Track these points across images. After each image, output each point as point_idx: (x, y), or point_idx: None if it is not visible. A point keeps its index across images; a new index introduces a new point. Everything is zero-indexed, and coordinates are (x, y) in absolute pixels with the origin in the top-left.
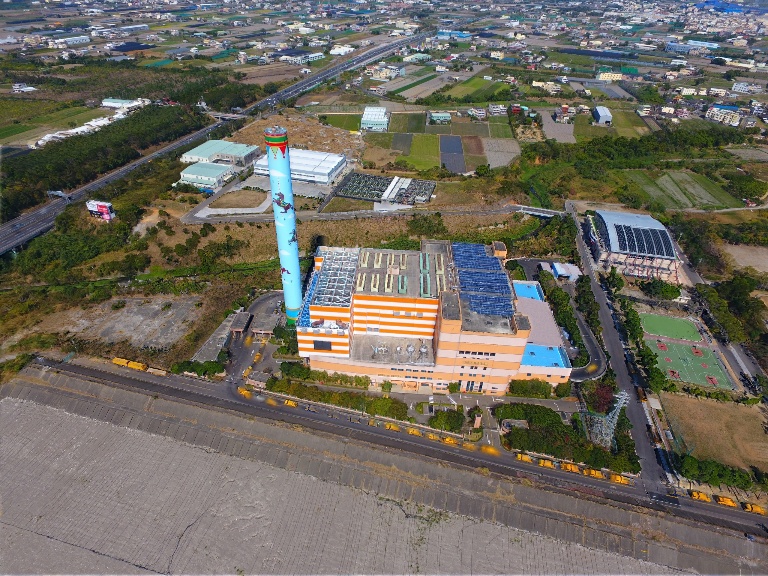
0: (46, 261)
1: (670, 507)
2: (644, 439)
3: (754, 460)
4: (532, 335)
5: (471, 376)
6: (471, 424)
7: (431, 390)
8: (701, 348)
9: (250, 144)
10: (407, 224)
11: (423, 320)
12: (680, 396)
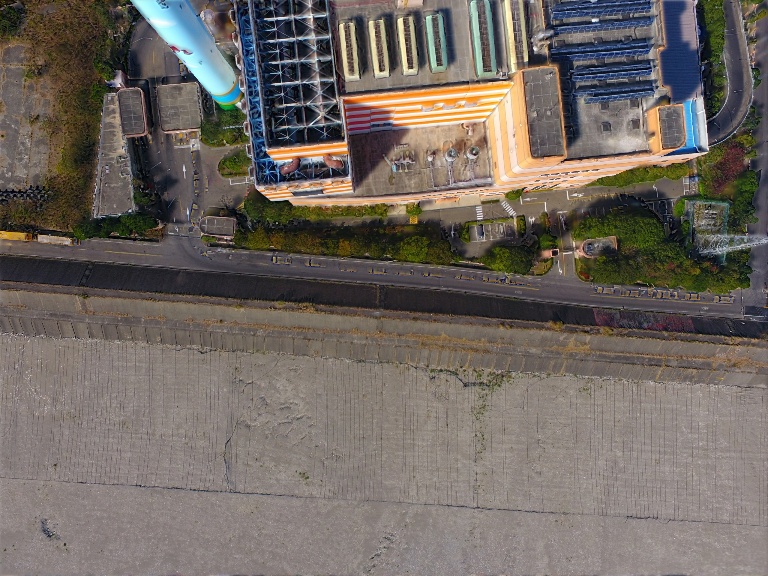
0: None
1: (764, 323)
2: (762, 229)
3: None
4: None
5: (545, 183)
6: (541, 258)
7: (478, 197)
8: None
9: None
10: None
11: (474, 107)
12: None
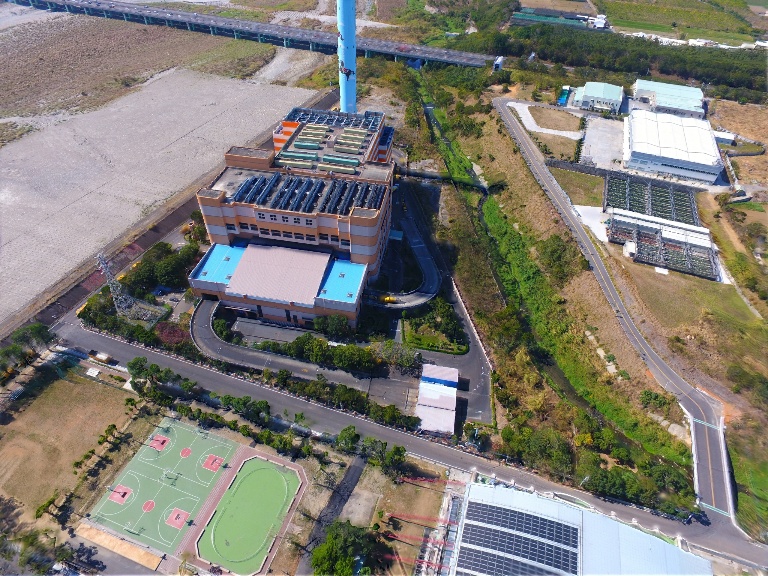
0: (445, 75)
1: None
2: (106, 349)
3: (5, 445)
4: (249, 261)
5: None
6: None
7: None
8: (182, 534)
9: (726, 115)
10: (551, 235)
11: None
12: (125, 422)
